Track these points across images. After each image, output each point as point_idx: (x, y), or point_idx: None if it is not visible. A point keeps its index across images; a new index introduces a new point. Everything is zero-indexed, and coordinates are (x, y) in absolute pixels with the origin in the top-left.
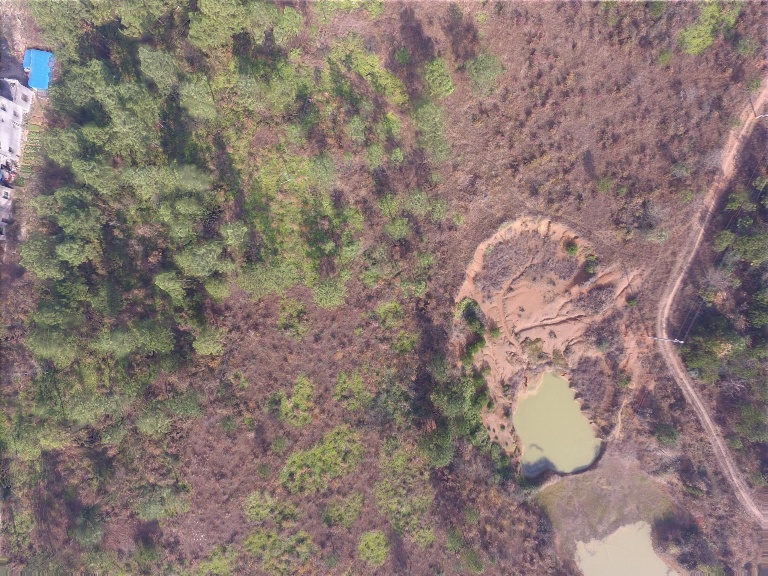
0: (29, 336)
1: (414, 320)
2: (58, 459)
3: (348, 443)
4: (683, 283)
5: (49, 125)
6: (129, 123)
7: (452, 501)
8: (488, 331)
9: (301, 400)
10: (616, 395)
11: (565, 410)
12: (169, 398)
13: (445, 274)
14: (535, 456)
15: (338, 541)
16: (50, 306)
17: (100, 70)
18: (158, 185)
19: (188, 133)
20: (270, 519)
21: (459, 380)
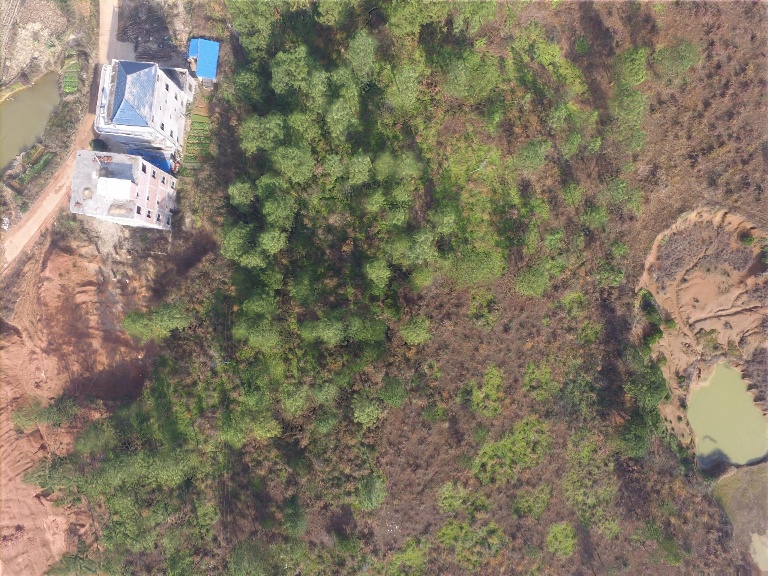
0: (208, 326)
1: (598, 310)
2: (244, 450)
3: (537, 434)
4: None
5: (220, 115)
6: (341, 110)
7: (636, 492)
8: (663, 322)
9: (491, 390)
10: None
11: (738, 401)
12: (365, 388)
13: (626, 264)
14: (709, 448)
15: (527, 533)
16: (257, 294)
17: (304, 57)
18: (371, 172)
19: (374, 122)
20: (462, 510)
21: None
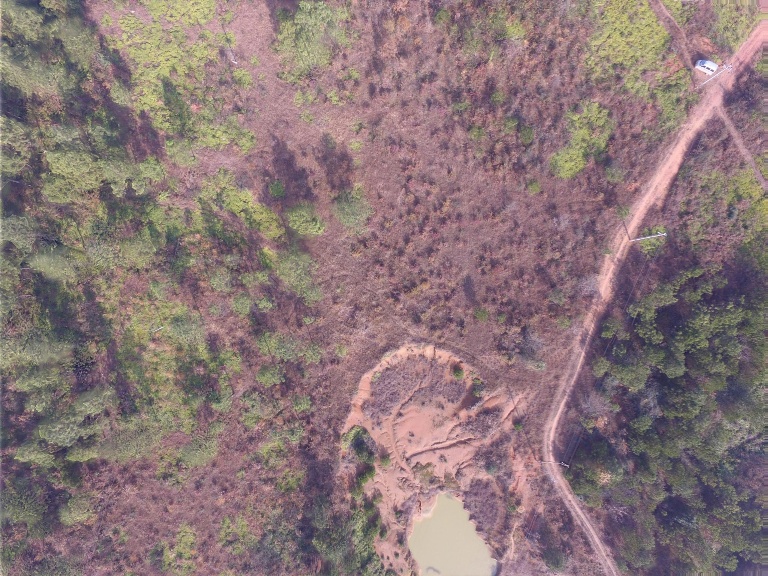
0: None
1: (298, 457)
2: None
3: None
4: (567, 406)
5: None
6: None
7: None
8: (379, 458)
9: (184, 548)
10: (507, 518)
11: (460, 531)
12: (46, 559)
13: (329, 408)
14: None
15: None
16: None
17: None
18: (14, 357)
19: (59, 282)
20: None
21: (348, 513)
